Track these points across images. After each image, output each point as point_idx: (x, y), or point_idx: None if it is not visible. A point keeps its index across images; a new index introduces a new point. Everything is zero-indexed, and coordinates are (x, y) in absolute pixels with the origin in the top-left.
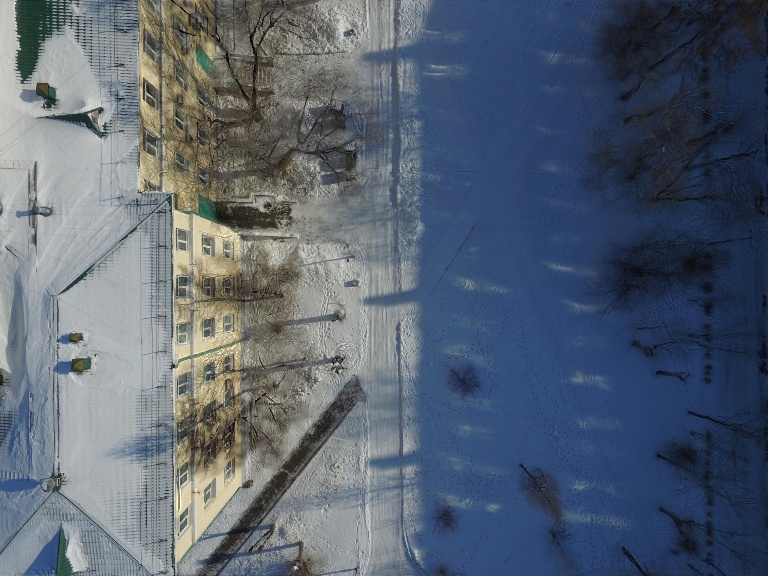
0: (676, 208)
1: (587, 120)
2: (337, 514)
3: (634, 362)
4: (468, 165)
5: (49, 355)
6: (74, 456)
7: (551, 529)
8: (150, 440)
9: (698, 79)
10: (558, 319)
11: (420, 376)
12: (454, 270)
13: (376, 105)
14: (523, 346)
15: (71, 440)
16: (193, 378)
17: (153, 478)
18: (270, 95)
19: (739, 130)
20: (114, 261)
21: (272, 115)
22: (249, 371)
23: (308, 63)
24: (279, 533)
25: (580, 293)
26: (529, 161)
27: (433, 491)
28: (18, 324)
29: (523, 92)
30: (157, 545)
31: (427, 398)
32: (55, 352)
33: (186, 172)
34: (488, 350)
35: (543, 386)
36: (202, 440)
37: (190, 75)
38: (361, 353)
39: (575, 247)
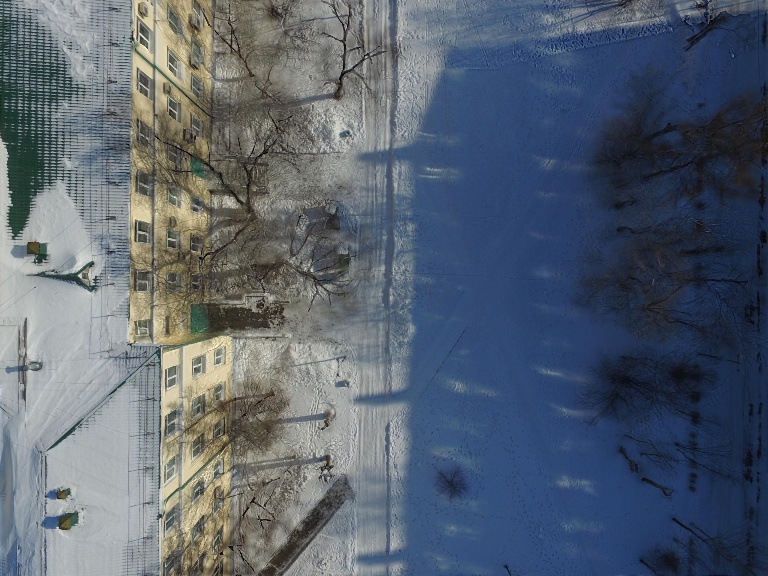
0: (665, 329)
1: (580, 227)
2: None
3: (620, 469)
4: (461, 268)
5: (37, 510)
6: None
7: None
8: None
9: (692, 190)
10: (546, 424)
11: (408, 476)
12: (444, 372)
13: (370, 206)
14: (511, 450)
15: None
16: (181, 509)
17: None
18: (265, 194)
19: (730, 255)
20: (103, 415)
21: (266, 215)
22: (239, 468)
23: (303, 162)
24: None
25: (568, 400)
26: (521, 267)
27: None
28: (7, 475)
29: (517, 197)
30: None
31: (415, 498)
32: (43, 507)
33: (178, 288)
34: (476, 453)
35: (529, 489)
36: (189, 563)
37: (184, 189)
38: (350, 452)
39: (565, 353)
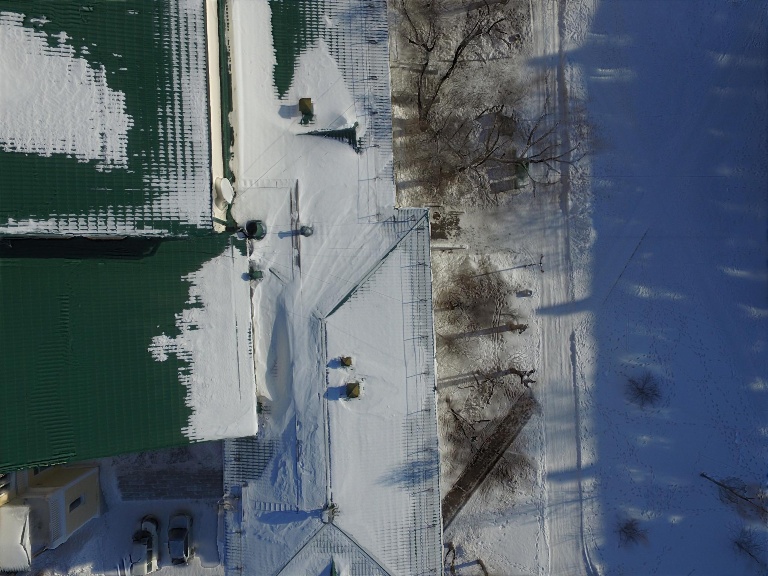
0: None
1: (760, 121)
2: (515, 530)
3: None
4: (638, 169)
5: (318, 381)
6: (346, 485)
7: (737, 539)
8: (416, 466)
9: None
10: (736, 324)
11: (596, 386)
12: (627, 277)
13: None
14: (701, 353)
15: (342, 469)
16: None
17: (421, 505)
18: (435, 103)
19: None
20: (376, 281)
21: (438, 124)
22: None
23: (472, 70)
24: (457, 552)
25: (759, 297)
26: (702, 164)
27: (613, 504)
28: (278, 349)
29: (693, 94)
30: (427, 575)
31: (604, 409)
32: (325, 377)
33: None
34: (665, 358)
35: (722, 393)
36: None
37: None
38: (535, 364)
39: (751, 250)
